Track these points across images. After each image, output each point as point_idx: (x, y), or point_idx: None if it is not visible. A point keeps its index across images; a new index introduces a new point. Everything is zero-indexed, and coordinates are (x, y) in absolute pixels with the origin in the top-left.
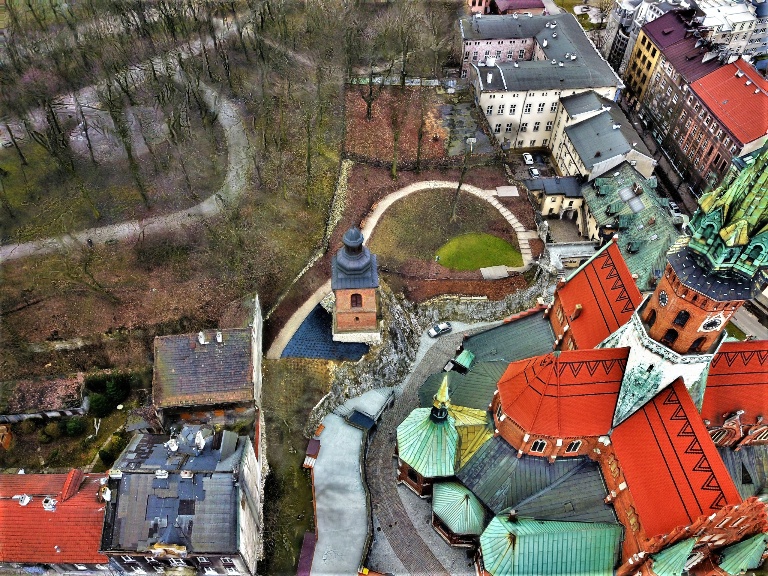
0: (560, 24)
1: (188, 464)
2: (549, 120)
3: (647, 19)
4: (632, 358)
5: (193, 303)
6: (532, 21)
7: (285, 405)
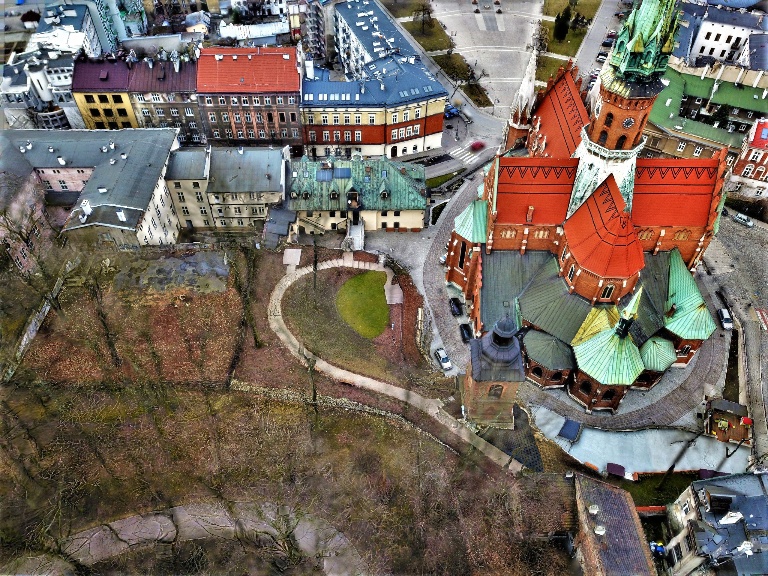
0: None
1: (762, 526)
2: (169, 205)
3: (55, 84)
4: (618, 176)
5: (506, 575)
6: (2, 160)
7: None
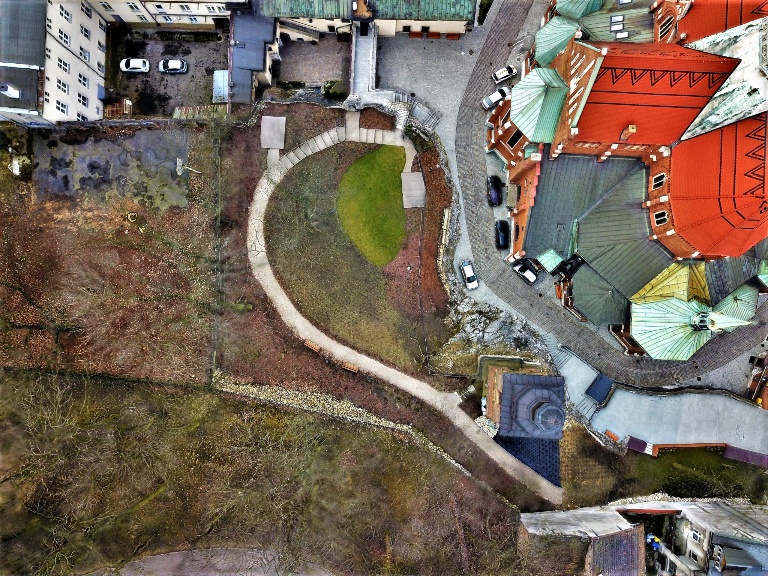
0: None
1: None
2: (79, 7)
3: None
4: None
5: None
6: None
7: (603, 478)
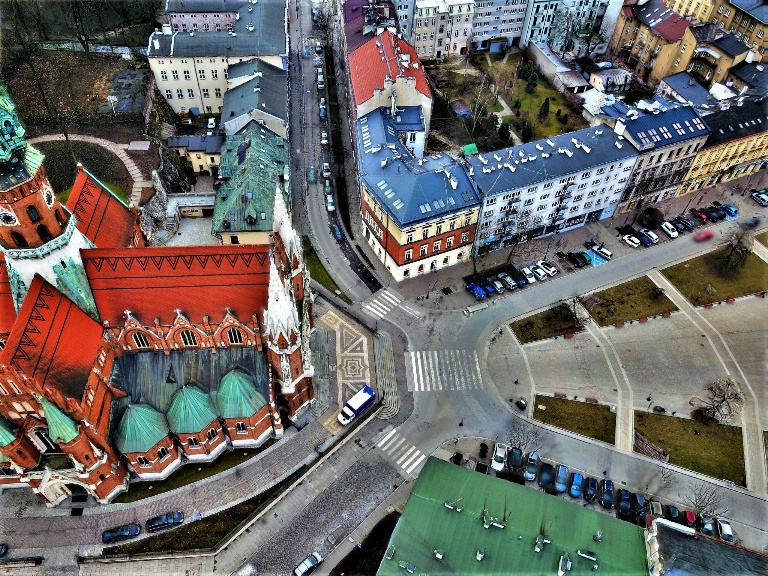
0: (263, 0)
1: None
2: (228, 87)
3: None
4: None
5: None
6: None
7: None
